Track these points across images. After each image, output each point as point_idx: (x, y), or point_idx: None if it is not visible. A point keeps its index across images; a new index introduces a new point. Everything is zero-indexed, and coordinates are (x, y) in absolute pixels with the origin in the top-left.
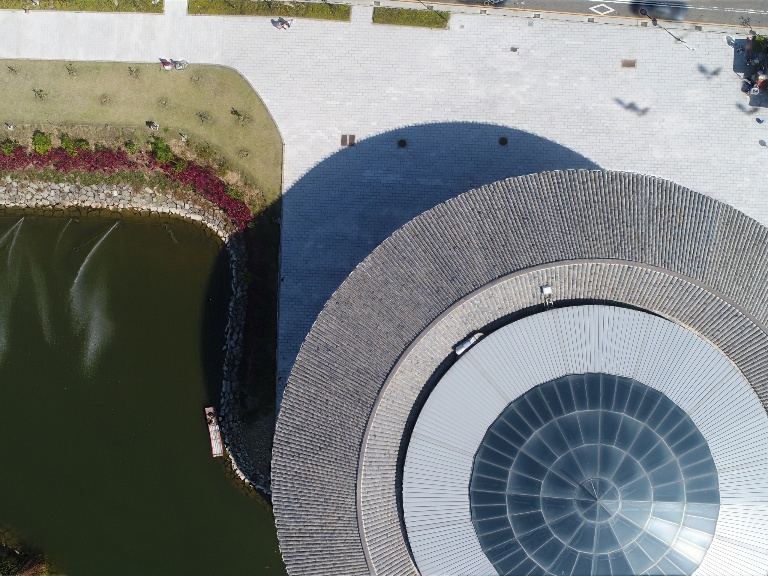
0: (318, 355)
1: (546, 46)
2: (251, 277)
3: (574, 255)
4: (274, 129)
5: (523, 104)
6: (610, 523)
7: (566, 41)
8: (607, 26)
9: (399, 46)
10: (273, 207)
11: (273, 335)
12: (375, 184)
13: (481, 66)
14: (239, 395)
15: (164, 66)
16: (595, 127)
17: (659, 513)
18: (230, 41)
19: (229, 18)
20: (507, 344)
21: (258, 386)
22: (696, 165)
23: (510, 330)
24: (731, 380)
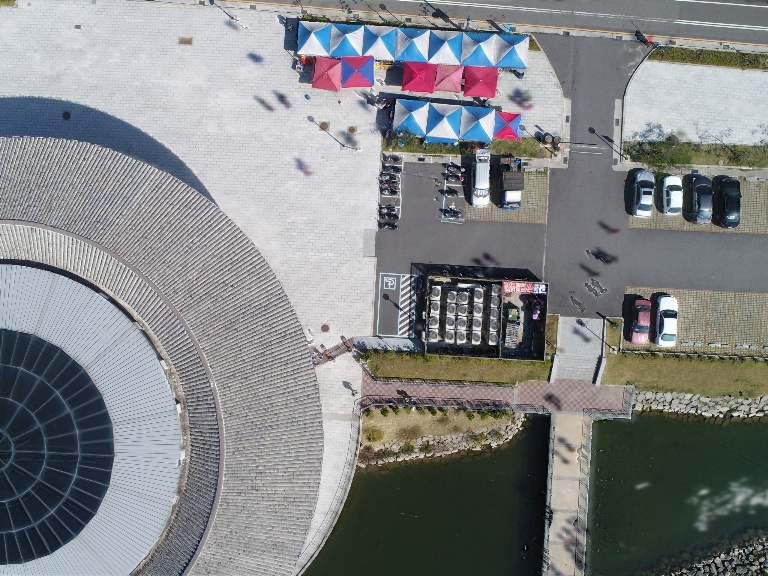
0: None
1: (108, 24)
2: None
3: None
4: None
5: (85, 80)
6: (5, 472)
7: (127, 19)
8: (166, 5)
9: None
10: None
11: None
12: None
13: (46, 43)
14: None
15: None
16: (153, 102)
17: (53, 463)
18: None
19: None
20: None
21: None
22: (248, 140)
23: None
24: (129, 337)
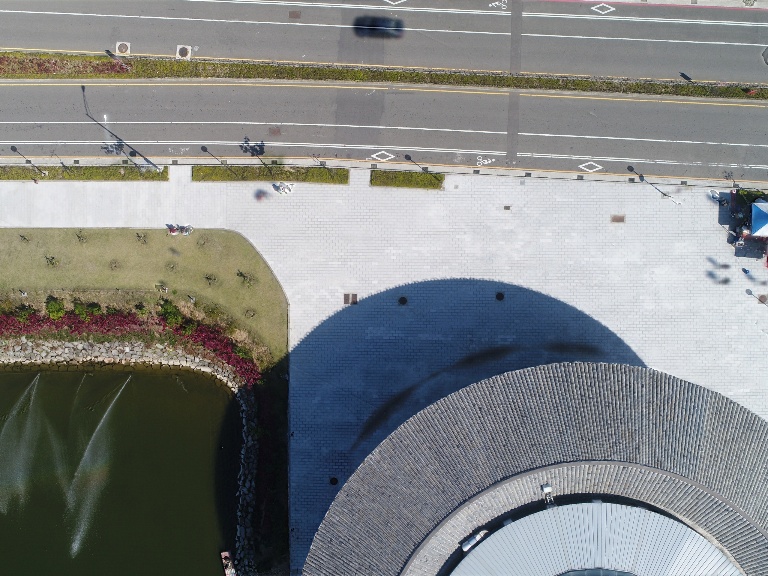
0: (331, 546)
1: (538, 204)
2: (261, 432)
3: (572, 457)
4: (279, 290)
5: (518, 260)
6: None
7: (557, 199)
8: (596, 183)
9: (397, 207)
10: (280, 364)
11: (285, 486)
12: (378, 340)
13: (476, 225)
14: (253, 541)
15: (171, 233)
16: (588, 281)
17: None
18: (234, 206)
19: (232, 184)
20: (511, 542)
21: (272, 537)
22: (686, 315)
23: (513, 528)
24: (724, 571)
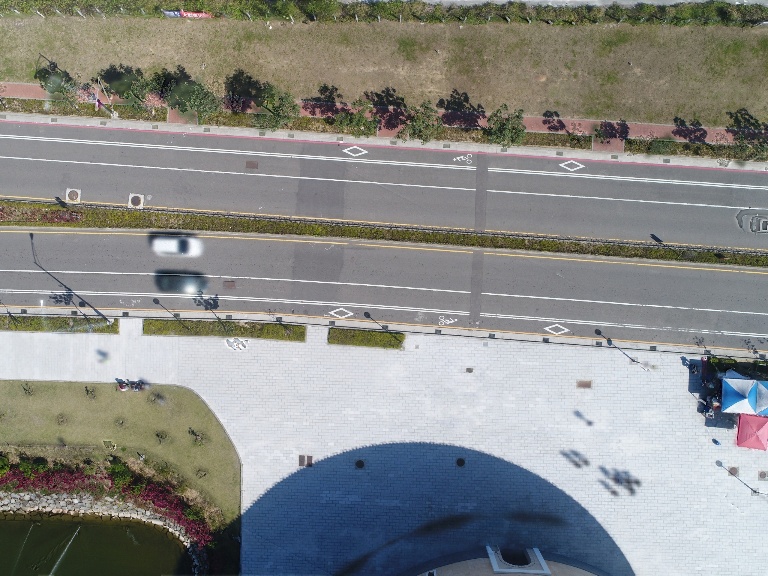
0: None
1: (501, 367)
2: None
3: None
4: (232, 449)
5: (480, 425)
6: None
7: (521, 362)
8: (562, 347)
9: (355, 367)
10: (232, 526)
11: None
12: (334, 505)
13: (437, 387)
14: None
15: (120, 389)
16: (552, 448)
17: None
18: (186, 361)
19: (184, 339)
20: None
21: None
22: (653, 486)
23: None
24: None
